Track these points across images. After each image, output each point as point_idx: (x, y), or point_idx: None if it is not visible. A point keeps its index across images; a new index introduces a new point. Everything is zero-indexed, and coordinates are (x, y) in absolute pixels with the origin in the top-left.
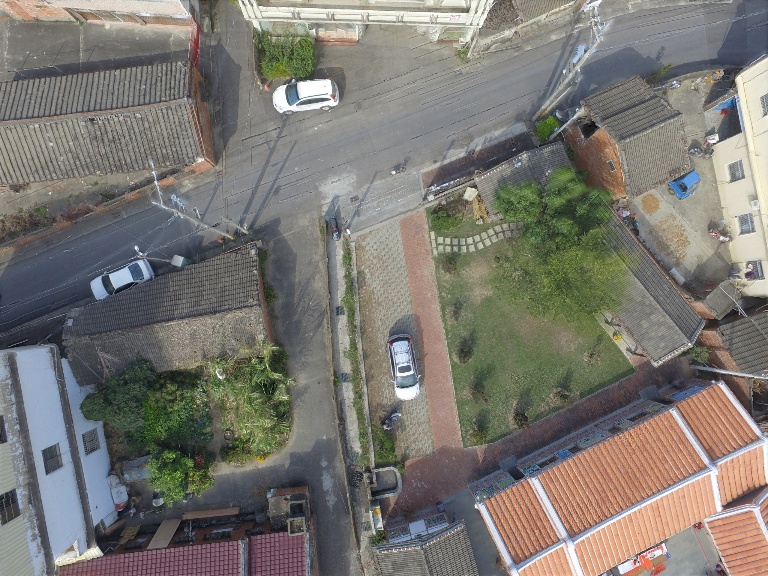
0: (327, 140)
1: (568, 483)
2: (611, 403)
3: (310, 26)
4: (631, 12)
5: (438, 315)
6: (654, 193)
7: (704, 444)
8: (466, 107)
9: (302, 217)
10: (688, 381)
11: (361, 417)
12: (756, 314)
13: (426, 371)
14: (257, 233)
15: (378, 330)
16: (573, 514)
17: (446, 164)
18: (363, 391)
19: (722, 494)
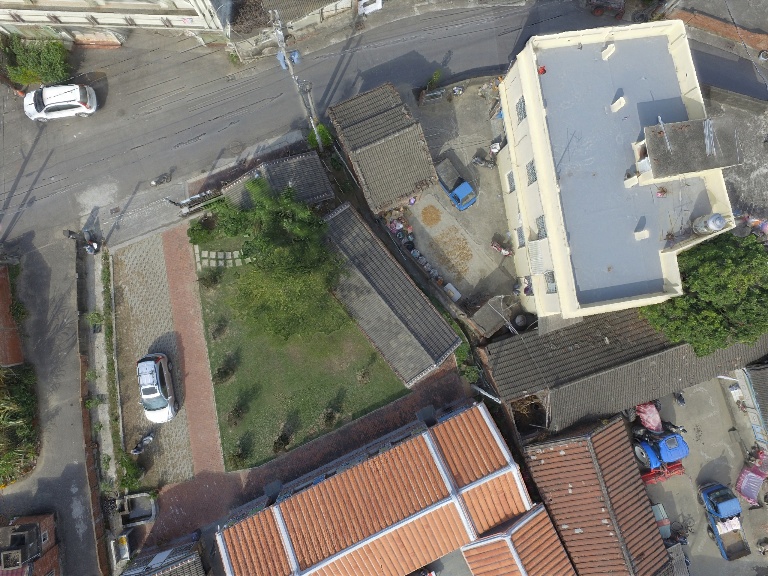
0: (87, 148)
1: (309, 512)
2: (385, 424)
3: (54, 29)
4: (417, 15)
5: (201, 333)
6: (435, 204)
7: (453, 470)
8: (238, 114)
9: (58, 230)
10: (465, 401)
11: (117, 440)
12: (526, 332)
13: (187, 392)
14: (10, 247)
15: (136, 349)
16: (308, 545)
17: (215, 174)
18: (119, 413)
19: (476, 522)
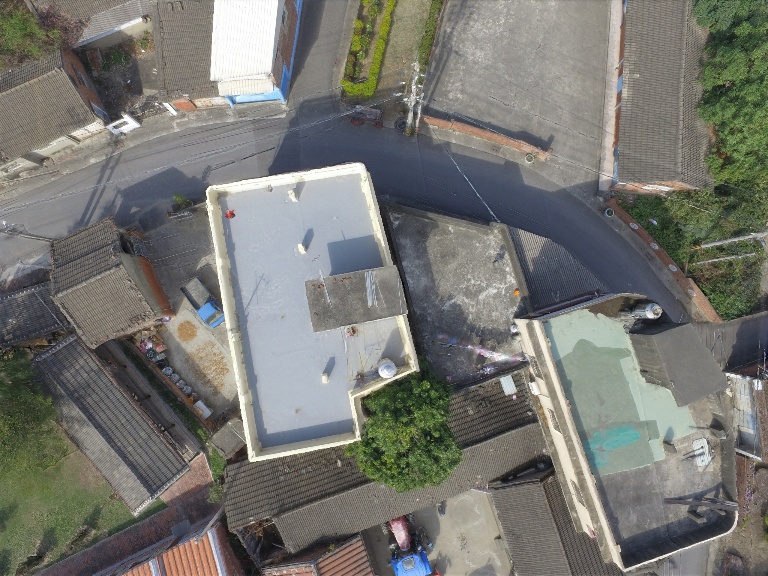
0: None
1: None
2: (141, 540)
3: None
4: (176, 131)
5: None
6: (192, 320)
7: None
8: None
9: None
10: None
11: None
12: None
13: None
14: None
15: None
16: None
17: None
18: None
19: None
